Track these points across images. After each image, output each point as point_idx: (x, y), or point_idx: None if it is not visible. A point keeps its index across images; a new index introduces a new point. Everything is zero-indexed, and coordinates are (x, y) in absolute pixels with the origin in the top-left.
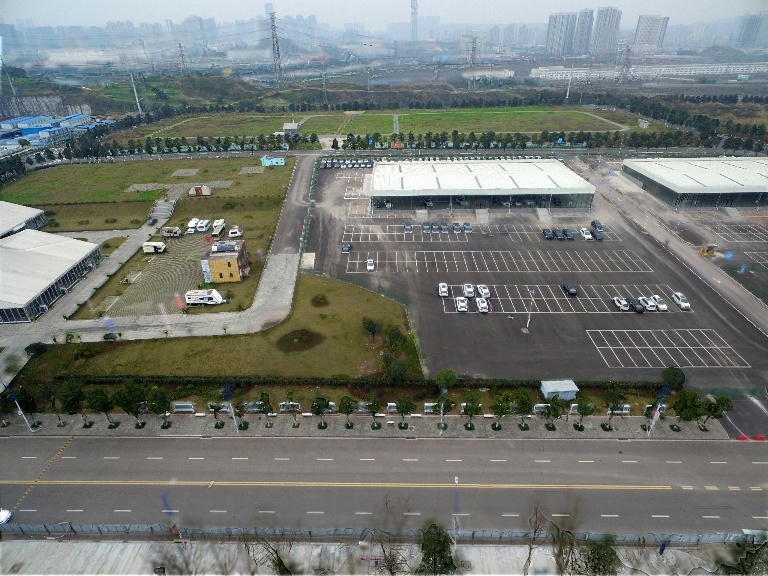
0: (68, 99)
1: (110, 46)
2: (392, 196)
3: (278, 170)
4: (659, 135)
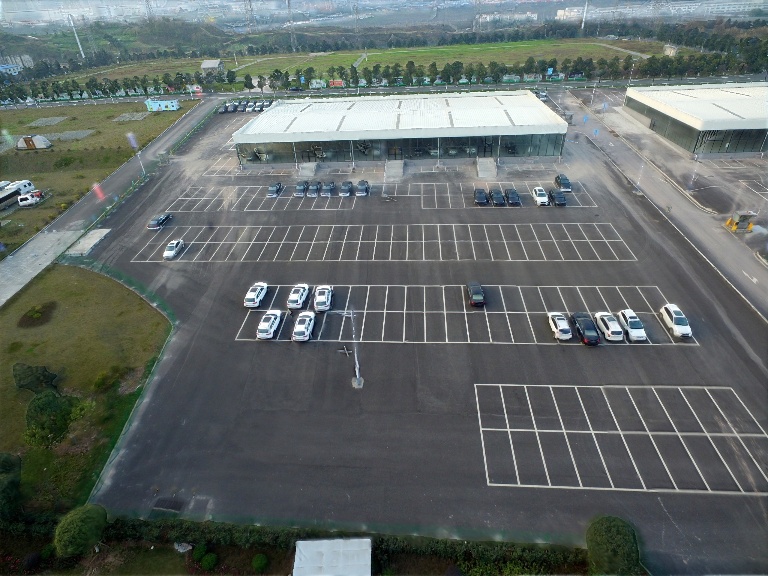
0: (7, 49)
1: None
2: (265, 143)
3: (163, 116)
4: (687, 60)
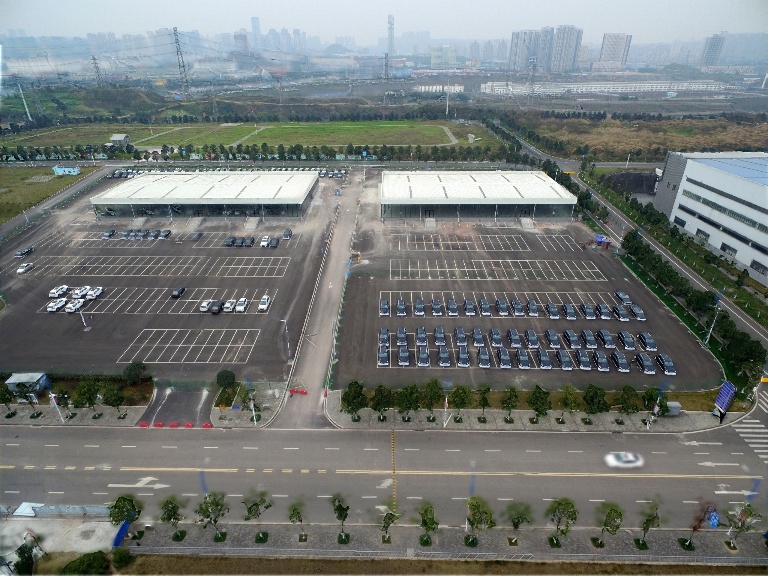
0: None
1: (14, 58)
2: (112, 204)
3: (65, 179)
4: (459, 149)
